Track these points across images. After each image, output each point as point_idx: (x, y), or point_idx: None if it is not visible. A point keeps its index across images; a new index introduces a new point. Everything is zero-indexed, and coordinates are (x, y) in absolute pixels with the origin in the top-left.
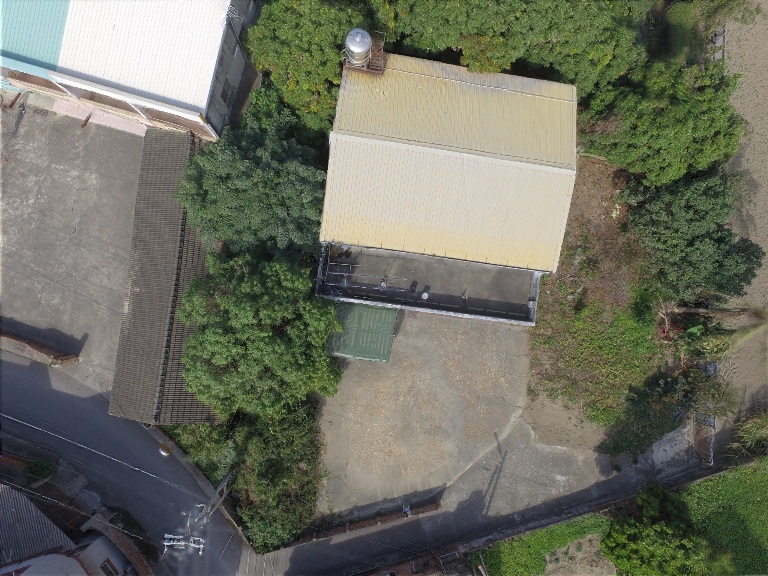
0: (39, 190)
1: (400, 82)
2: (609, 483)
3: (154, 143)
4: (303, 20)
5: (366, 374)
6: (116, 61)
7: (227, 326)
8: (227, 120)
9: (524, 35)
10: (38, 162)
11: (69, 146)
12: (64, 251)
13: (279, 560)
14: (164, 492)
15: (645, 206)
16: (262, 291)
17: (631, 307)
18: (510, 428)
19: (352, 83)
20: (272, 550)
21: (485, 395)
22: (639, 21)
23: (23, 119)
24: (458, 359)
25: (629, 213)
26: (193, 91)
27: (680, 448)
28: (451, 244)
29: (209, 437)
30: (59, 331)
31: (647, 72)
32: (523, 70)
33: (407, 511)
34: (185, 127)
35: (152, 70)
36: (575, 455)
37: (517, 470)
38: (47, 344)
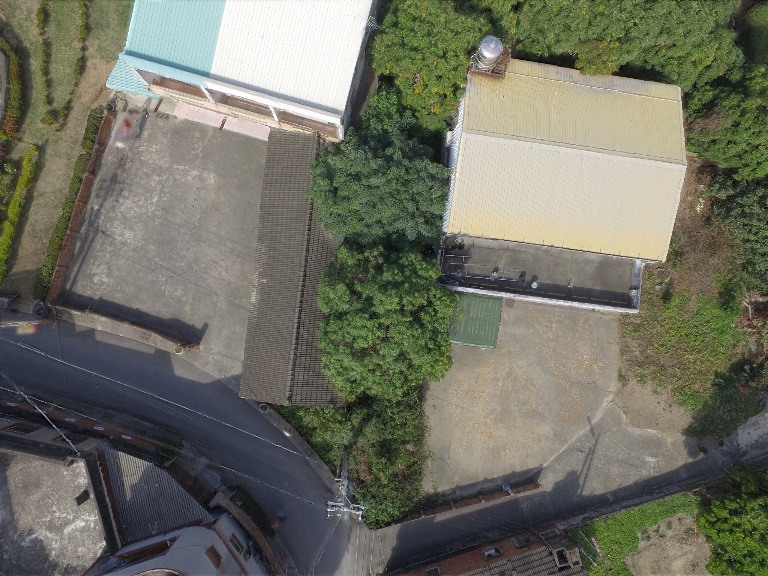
0: (162, 189)
1: (519, 85)
2: (696, 464)
3: (278, 144)
4: (438, 28)
5: (467, 361)
6: (264, 68)
7: (370, 312)
8: (349, 122)
9: (641, 40)
10: (161, 163)
11: (189, 148)
12: (185, 246)
13: (386, 536)
14: (279, 472)
15: (736, 199)
16: (402, 279)
17: (716, 296)
18: (602, 412)
19: (476, 86)
20: (384, 526)
21: (578, 380)
22: (724, 24)
23: (146, 123)
24: (553, 346)
25: (716, 207)
26: (333, 95)
27: (763, 431)
28: (568, 235)
29: (333, 418)
30: (181, 321)
31: (746, 73)
32: (631, 72)
33: (508, 490)
34: (312, 129)
35: (296, 76)
36: (664, 438)
37: (609, 452)
38: (170, 333)
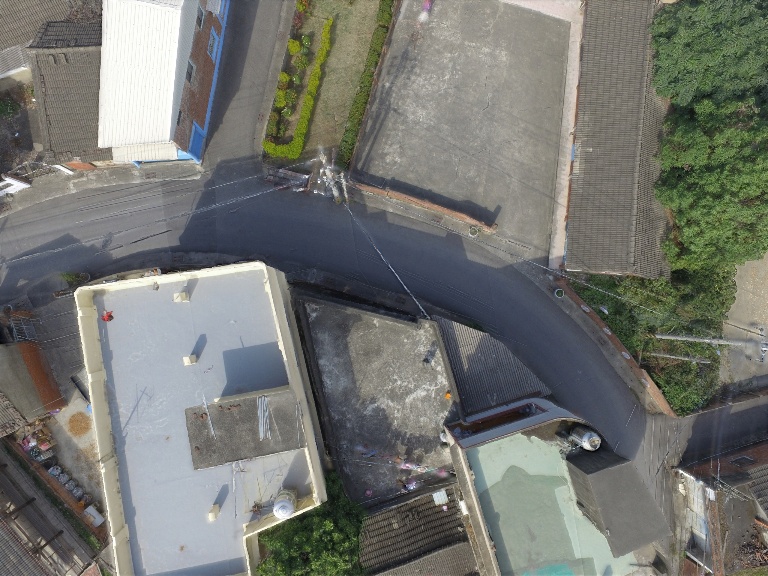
0: (454, 66)
1: None
2: None
3: (602, 8)
4: None
5: None
6: None
7: None
8: None
9: None
10: (452, 39)
11: (480, 24)
12: (478, 125)
13: None
14: (572, 361)
15: None
16: None
17: None
18: None
19: None
20: (691, 413)
21: None
22: None
23: None
24: None
25: None
26: None
27: None
28: None
29: (664, 292)
30: (474, 203)
31: None
32: None
33: None
34: None
35: None
36: None
37: None
38: None
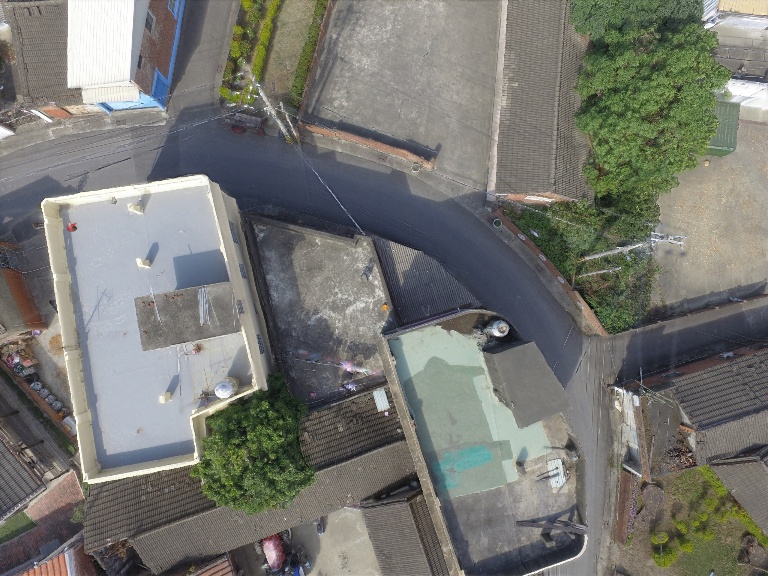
0: (395, 18)
1: None
2: None
3: None
4: None
5: (690, 178)
6: None
7: None
8: None
9: None
10: None
11: None
12: (419, 71)
13: (617, 348)
14: (511, 286)
15: None
16: (693, 41)
17: None
18: None
19: None
20: (622, 331)
21: None
22: None
23: None
24: None
25: None
26: None
27: None
28: None
29: (587, 212)
30: (416, 142)
31: None
32: None
33: (738, 300)
34: None
35: None
36: None
37: None
38: None
